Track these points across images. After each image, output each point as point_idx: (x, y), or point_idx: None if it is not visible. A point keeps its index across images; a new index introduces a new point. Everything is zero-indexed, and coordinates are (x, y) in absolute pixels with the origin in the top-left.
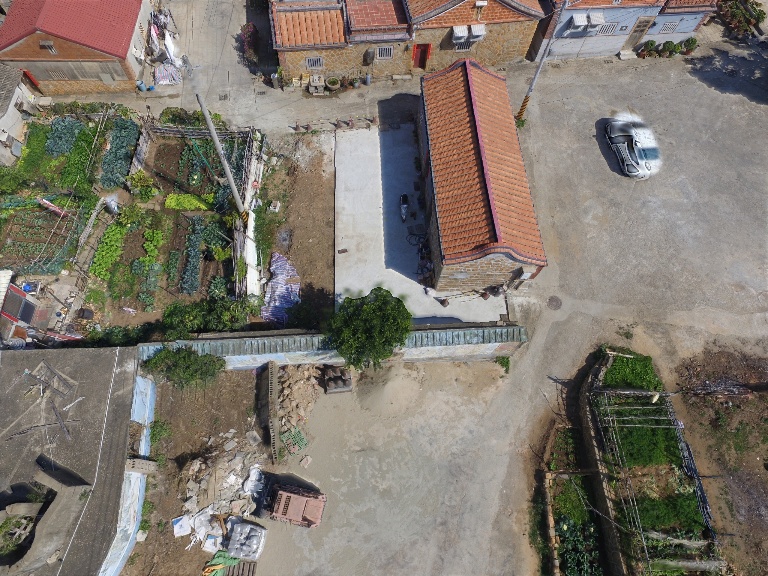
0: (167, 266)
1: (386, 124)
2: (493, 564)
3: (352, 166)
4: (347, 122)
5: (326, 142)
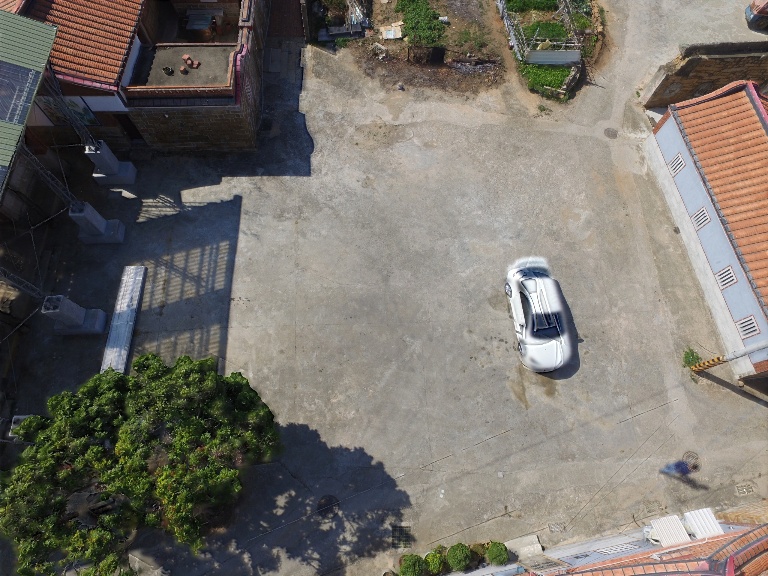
0: None
1: None
2: (625, 1)
3: None
4: None
5: None
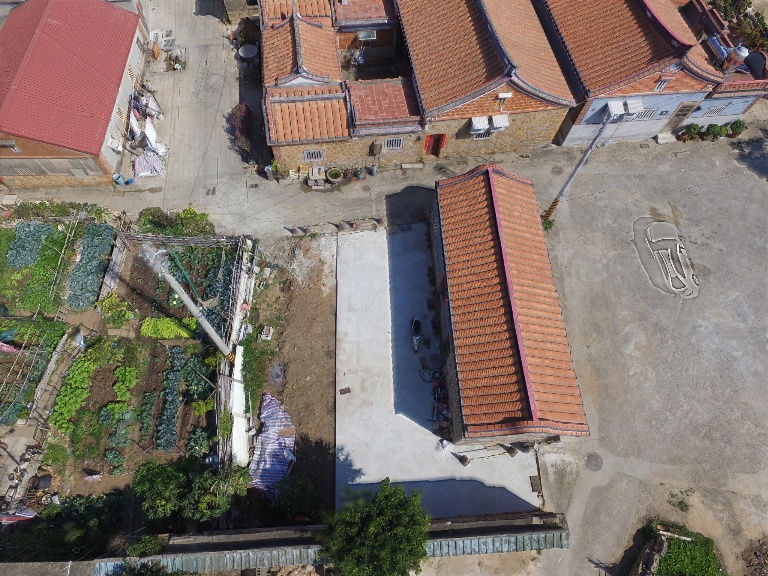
0: (141, 412)
1: (395, 225)
2: None
3: (356, 278)
4: (351, 222)
5: (327, 247)
